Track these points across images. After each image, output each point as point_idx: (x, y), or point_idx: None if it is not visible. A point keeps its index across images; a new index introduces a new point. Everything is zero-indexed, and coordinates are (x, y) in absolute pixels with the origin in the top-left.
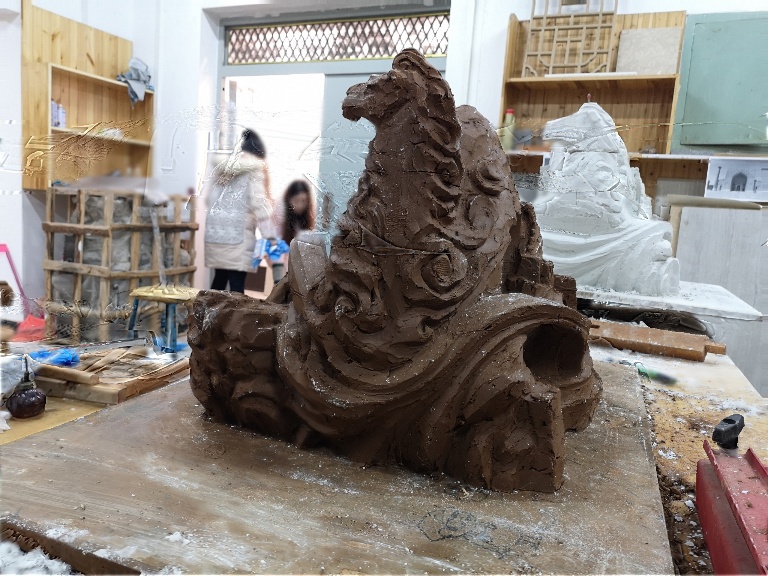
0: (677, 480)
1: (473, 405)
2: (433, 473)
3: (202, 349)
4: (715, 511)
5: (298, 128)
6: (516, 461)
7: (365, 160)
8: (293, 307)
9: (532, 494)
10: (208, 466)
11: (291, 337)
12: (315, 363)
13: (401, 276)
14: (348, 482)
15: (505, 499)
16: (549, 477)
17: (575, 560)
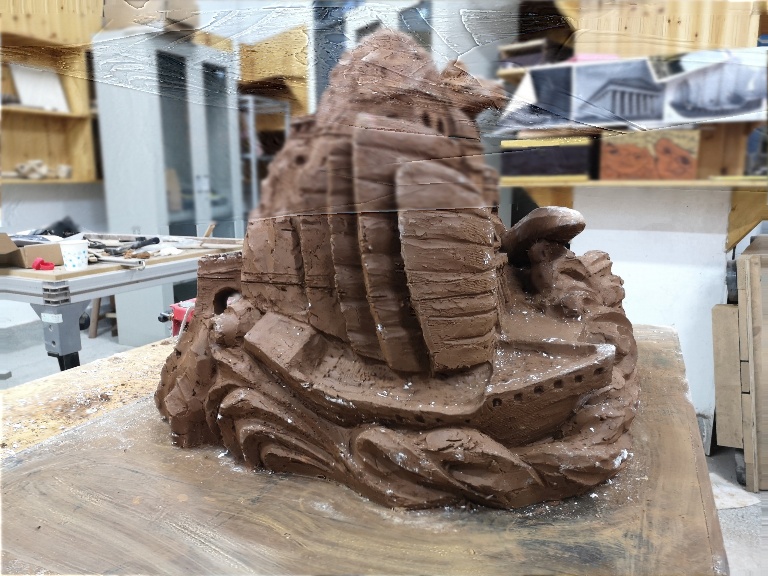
0: None
1: None
2: None
3: None
4: None
5: None
6: None
7: None
8: None
9: None
10: None
11: None
12: None
13: None
14: None
15: None
16: None
17: None
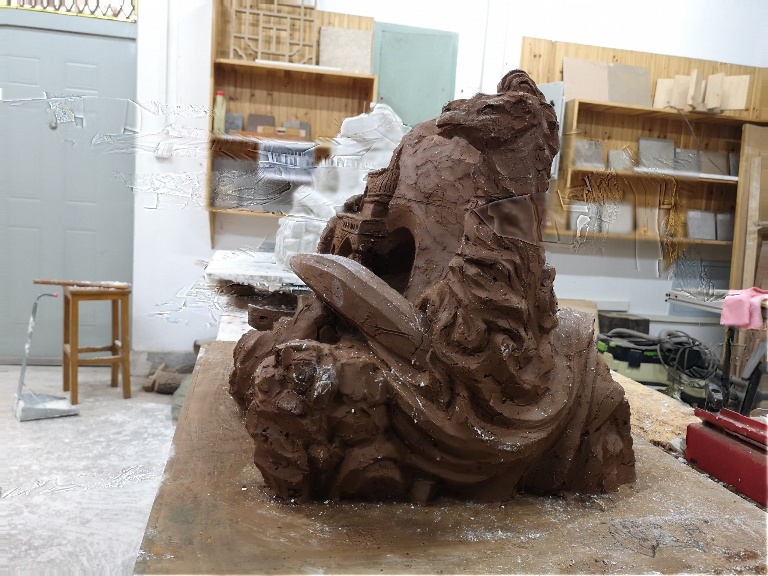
0: (653, 443)
1: (597, 420)
2: (562, 492)
3: (304, 418)
4: (763, 463)
5: (692, 179)
6: (616, 461)
7: (484, 184)
8: (381, 348)
9: (628, 487)
10: (388, 559)
11: (416, 385)
12: (469, 410)
13: (539, 306)
14: (517, 526)
15: (624, 498)
16: (633, 468)
17: (733, 533)
